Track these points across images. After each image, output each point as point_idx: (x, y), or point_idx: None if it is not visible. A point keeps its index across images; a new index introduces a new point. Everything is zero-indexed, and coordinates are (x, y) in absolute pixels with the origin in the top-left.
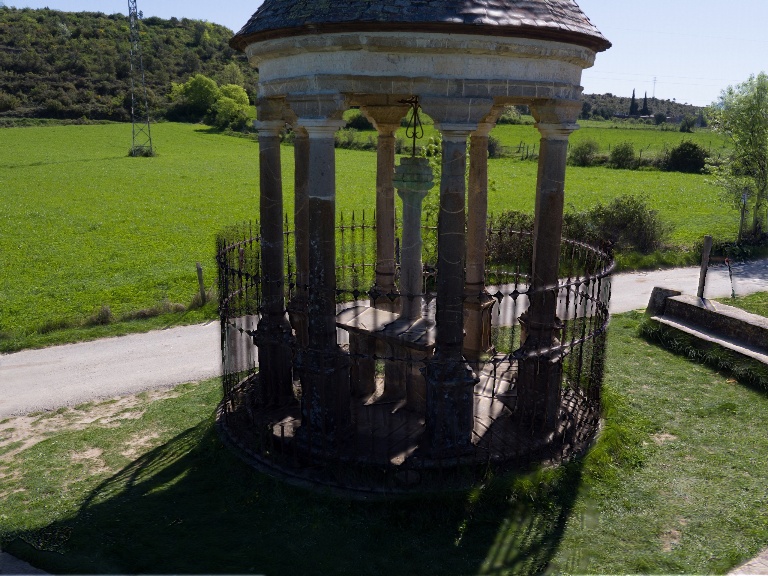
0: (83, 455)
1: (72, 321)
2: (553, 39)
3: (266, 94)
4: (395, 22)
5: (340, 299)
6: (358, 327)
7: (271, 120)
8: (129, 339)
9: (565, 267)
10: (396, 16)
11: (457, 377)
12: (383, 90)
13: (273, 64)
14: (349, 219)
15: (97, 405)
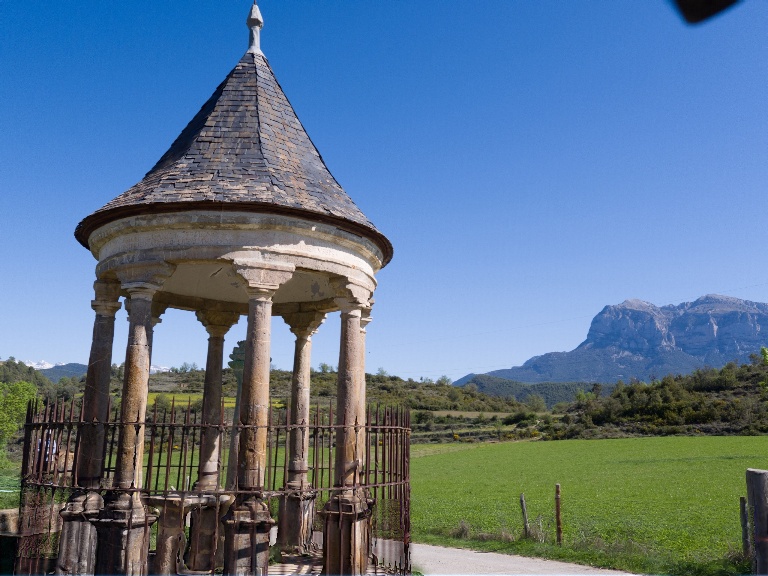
0: None
1: (446, 531)
2: (102, 224)
3: None
4: None
5: (605, 563)
6: None
7: None
8: (426, 547)
9: None
10: None
11: None
12: None
13: None
14: None
15: None
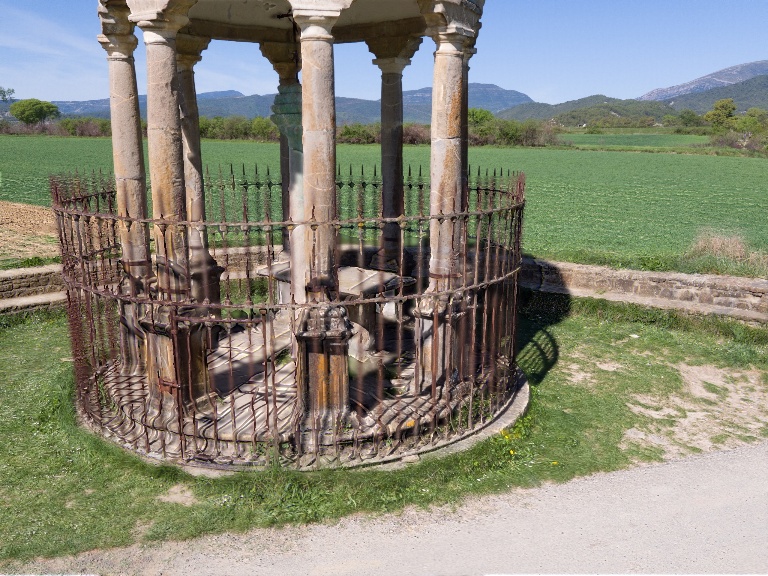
0: (613, 366)
1: None
2: None
3: None
4: None
5: None
6: None
7: None
8: None
9: None
10: None
11: None
12: None
13: None
14: None
15: (728, 435)
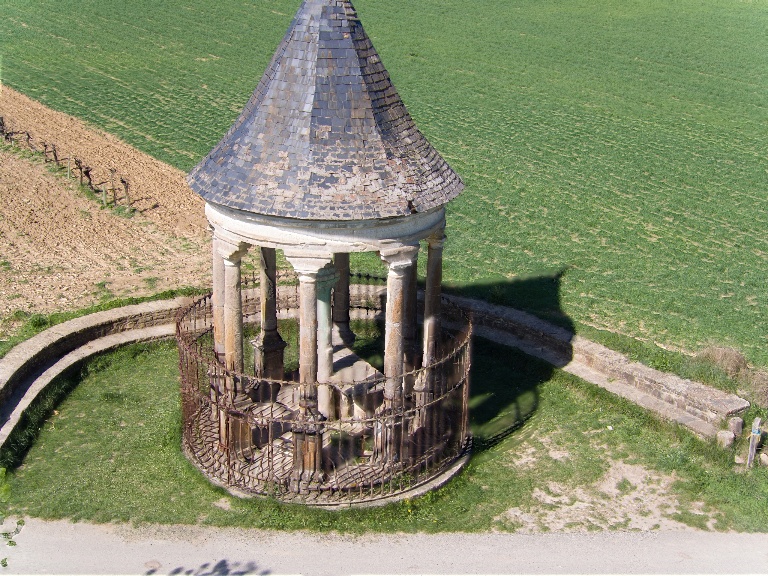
0: (562, 454)
1: None
2: None
3: None
4: None
5: None
6: None
7: None
8: None
9: None
10: None
11: None
12: None
13: None
14: None
15: (582, 523)
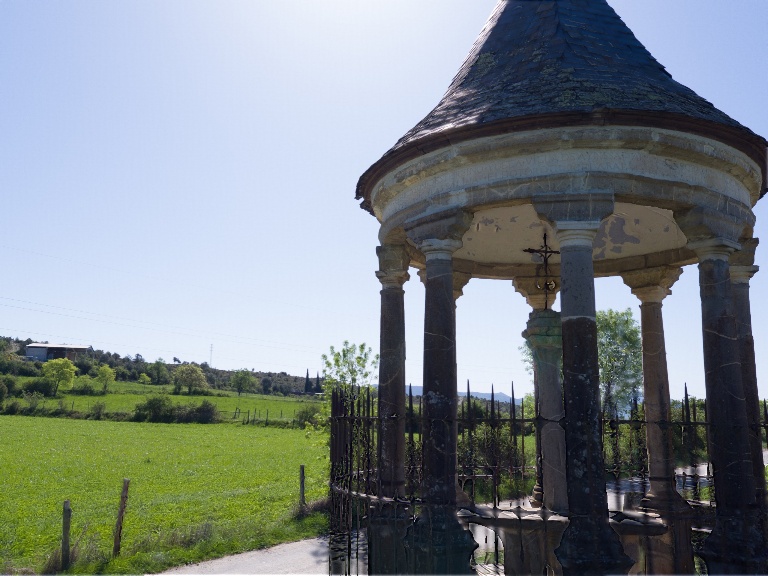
0: None
1: None
2: None
3: (474, 201)
4: (694, 122)
5: (260, 543)
6: (539, 519)
7: (454, 239)
8: None
9: (469, 494)
10: (699, 115)
11: (767, 551)
12: (664, 195)
13: (494, 166)
14: (121, 475)
15: None
